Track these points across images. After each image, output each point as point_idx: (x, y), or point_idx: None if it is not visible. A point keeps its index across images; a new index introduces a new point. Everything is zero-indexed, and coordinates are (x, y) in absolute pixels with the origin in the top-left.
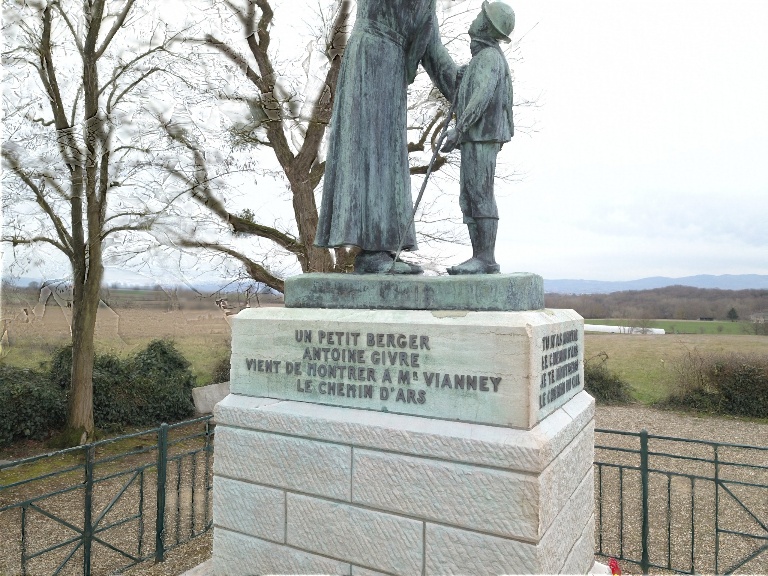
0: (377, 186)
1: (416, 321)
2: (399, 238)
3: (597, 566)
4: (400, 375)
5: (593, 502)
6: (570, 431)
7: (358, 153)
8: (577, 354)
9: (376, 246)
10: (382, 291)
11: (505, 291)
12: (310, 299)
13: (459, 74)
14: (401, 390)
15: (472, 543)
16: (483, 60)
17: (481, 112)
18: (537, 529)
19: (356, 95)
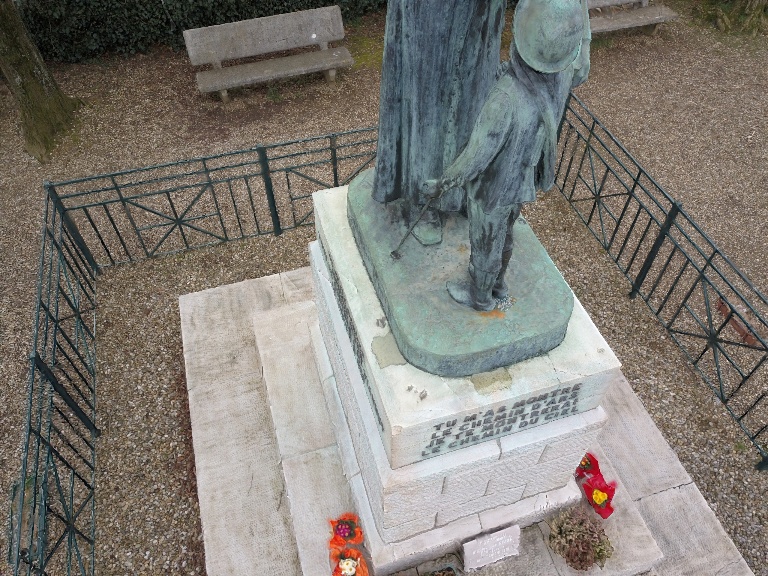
0: (418, 146)
1: (362, 336)
2: (440, 201)
3: (562, 491)
4: (357, 353)
5: (573, 466)
6: (487, 460)
7: (390, 112)
8: (576, 396)
9: (413, 201)
10: (373, 274)
11: (437, 363)
12: (351, 222)
13: (496, 76)
14: (358, 361)
15: (369, 471)
16: (484, 111)
17: (466, 181)
18: (383, 509)
19: (390, 40)
